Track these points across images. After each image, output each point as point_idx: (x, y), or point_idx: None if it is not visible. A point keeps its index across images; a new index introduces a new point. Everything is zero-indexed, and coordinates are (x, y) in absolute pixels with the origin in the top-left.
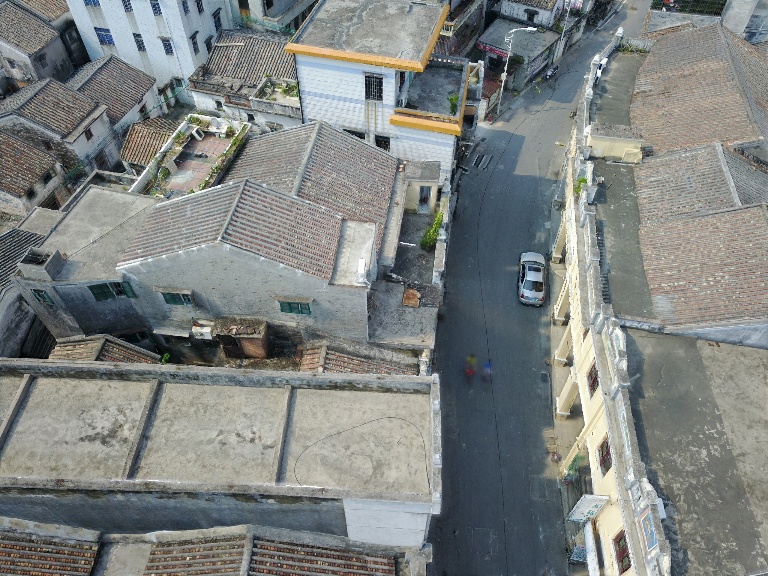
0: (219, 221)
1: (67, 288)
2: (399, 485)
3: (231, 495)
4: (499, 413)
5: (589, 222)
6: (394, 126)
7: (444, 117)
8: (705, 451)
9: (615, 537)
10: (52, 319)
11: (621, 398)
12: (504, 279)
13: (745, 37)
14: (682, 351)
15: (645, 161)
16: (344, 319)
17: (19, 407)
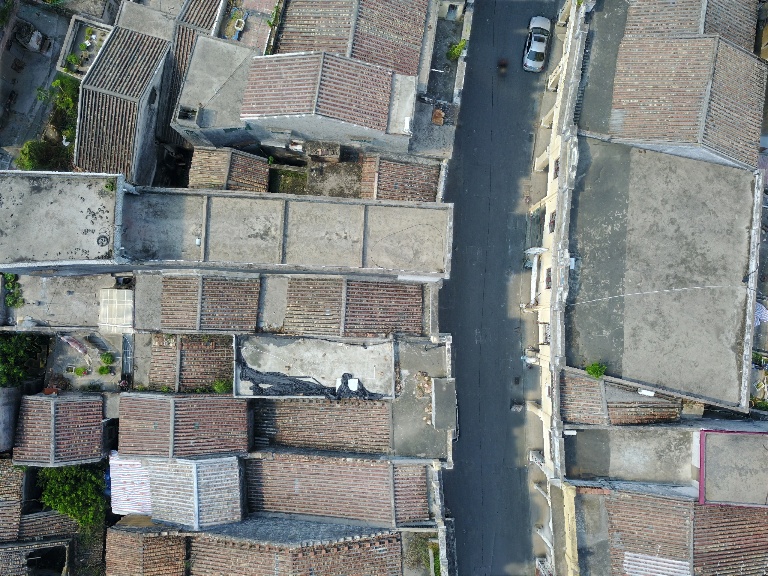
0: (310, 92)
1: (208, 130)
2: (428, 264)
3: None
4: (494, 167)
5: (581, 41)
6: None
7: None
8: (611, 227)
9: (548, 269)
10: (194, 140)
11: (567, 196)
12: (513, 44)
13: None
14: (619, 156)
15: None
16: (393, 145)
17: (207, 216)
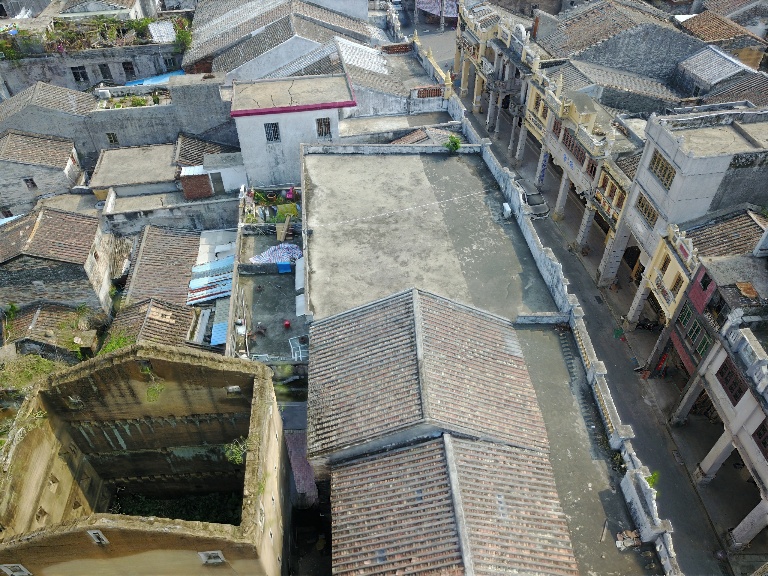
0: None
1: None
2: None
3: None
4: None
5: None
6: None
7: None
8: (474, 248)
9: None
10: None
11: None
12: None
13: None
14: (492, 311)
15: None
16: None
17: None
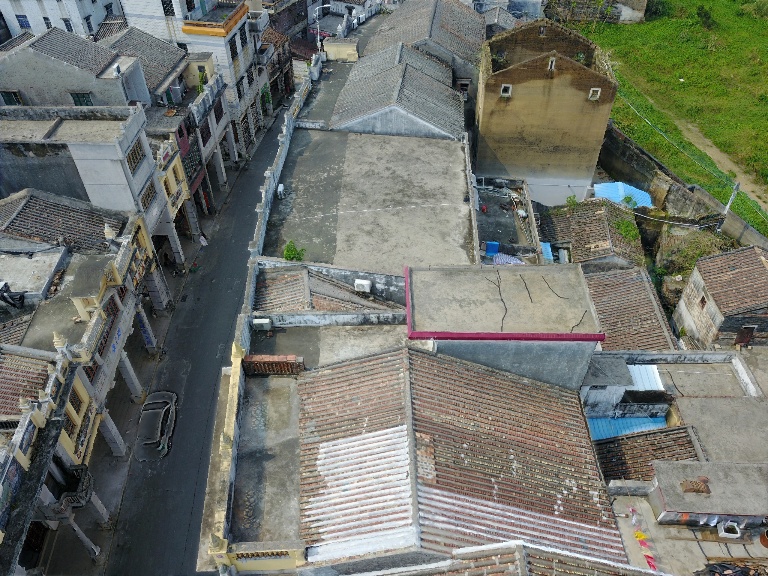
0: None
1: None
2: None
3: (8, 148)
4: None
5: (304, 83)
6: (186, 34)
7: (213, 23)
8: (326, 174)
9: None
10: None
11: None
12: None
13: (477, 8)
14: (337, 138)
15: (361, 59)
16: None
17: None
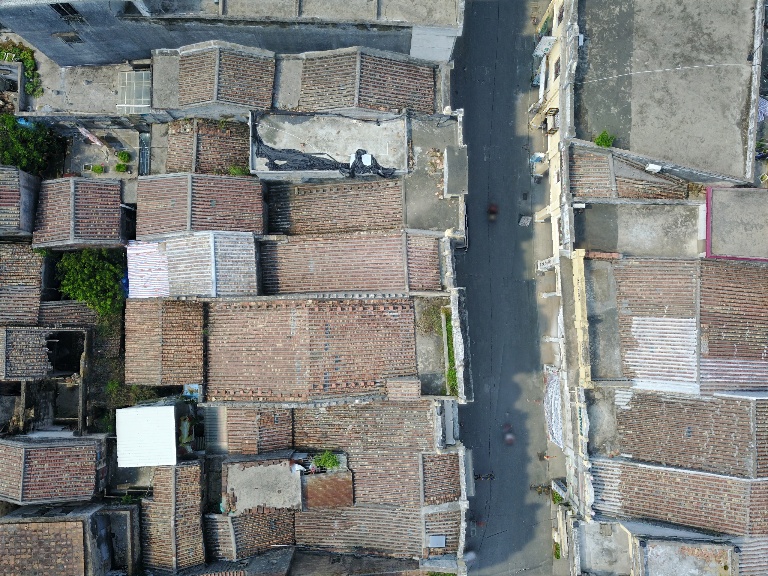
0: None
1: None
2: (441, 21)
3: (355, 25)
4: None
5: None
6: None
7: None
8: (618, 8)
9: (556, 62)
10: None
11: None
12: None
13: None
14: None
15: None
16: None
17: None
